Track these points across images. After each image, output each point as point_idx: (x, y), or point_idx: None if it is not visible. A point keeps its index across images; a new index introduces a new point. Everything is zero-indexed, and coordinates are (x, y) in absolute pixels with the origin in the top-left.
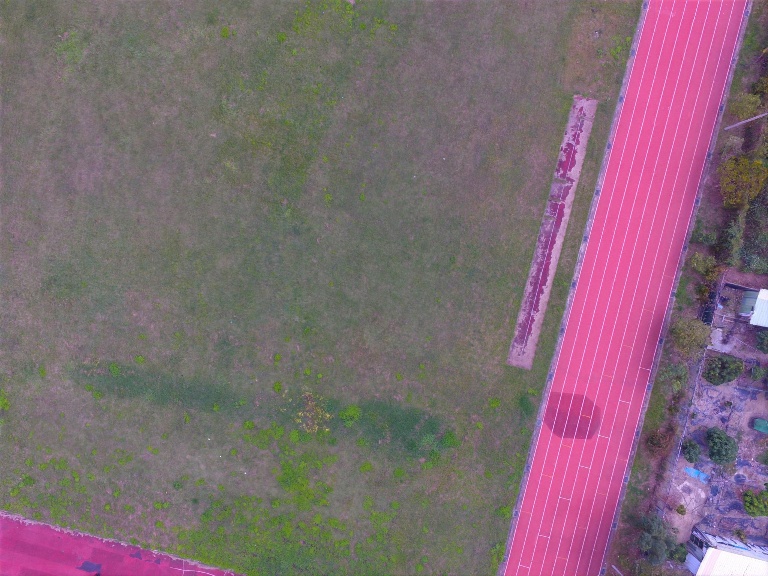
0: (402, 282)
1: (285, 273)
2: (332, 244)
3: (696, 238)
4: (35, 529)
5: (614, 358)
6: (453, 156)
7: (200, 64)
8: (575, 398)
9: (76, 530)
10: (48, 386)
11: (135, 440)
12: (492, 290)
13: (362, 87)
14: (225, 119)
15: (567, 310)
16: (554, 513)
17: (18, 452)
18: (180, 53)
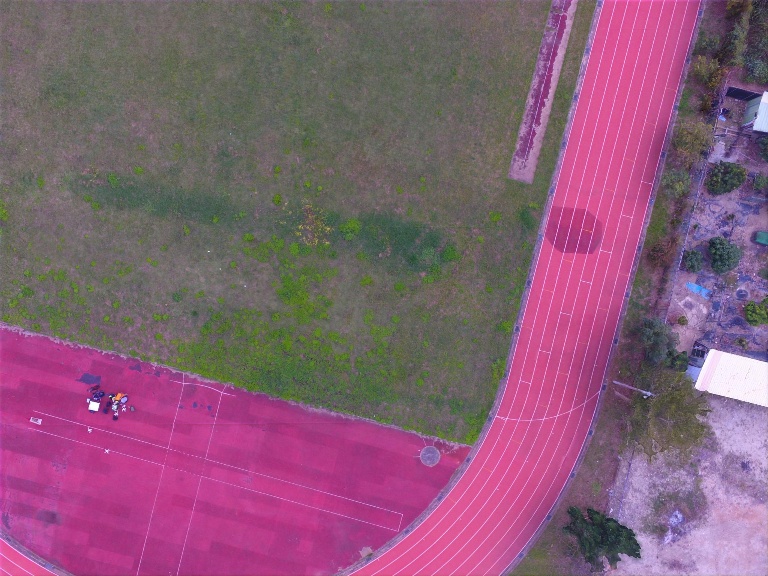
0: (403, 94)
1: (285, 84)
2: (332, 55)
3: (699, 46)
4: (34, 341)
5: (616, 172)
6: None
7: None
8: (577, 212)
9: (75, 342)
10: (47, 197)
11: (134, 252)
12: (493, 102)
13: None
14: None
15: (569, 123)
16: (555, 328)
17: (17, 263)
18: None
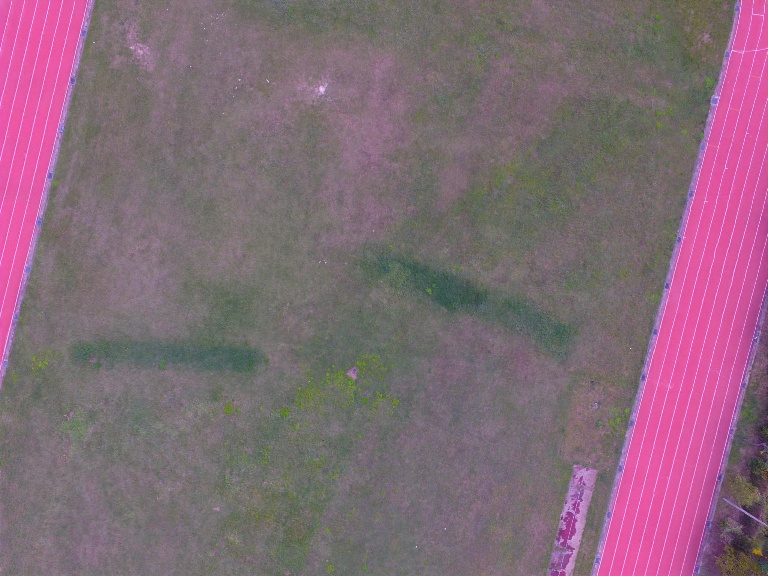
0: None
1: None
2: None
3: None
4: None
5: None
6: (454, 526)
7: (204, 440)
8: None
9: None
10: None
11: None
12: None
13: (364, 460)
14: (228, 493)
15: None
16: None
17: None
18: (184, 430)
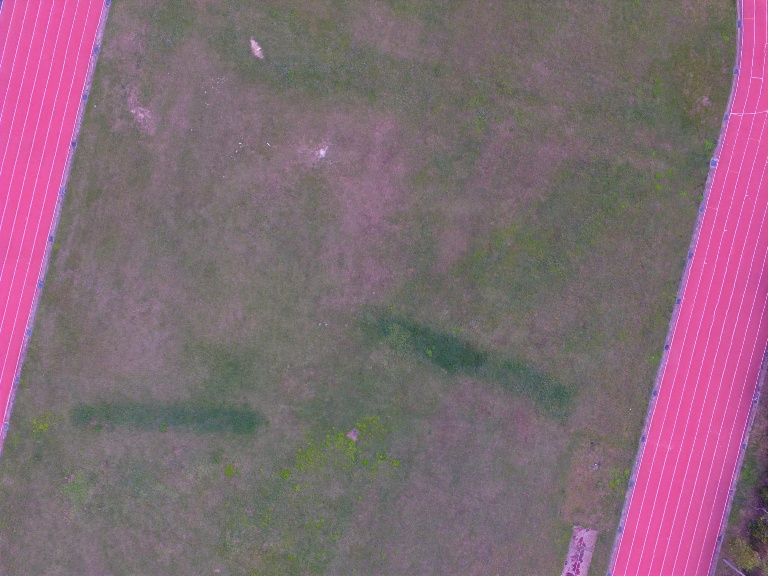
0: None
1: None
2: None
3: None
4: None
5: None
6: None
7: (204, 502)
8: None
9: None
10: None
11: None
12: None
13: (364, 521)
14: (229, 555)
15: None
16: None
17: None
18: (185, 492)
